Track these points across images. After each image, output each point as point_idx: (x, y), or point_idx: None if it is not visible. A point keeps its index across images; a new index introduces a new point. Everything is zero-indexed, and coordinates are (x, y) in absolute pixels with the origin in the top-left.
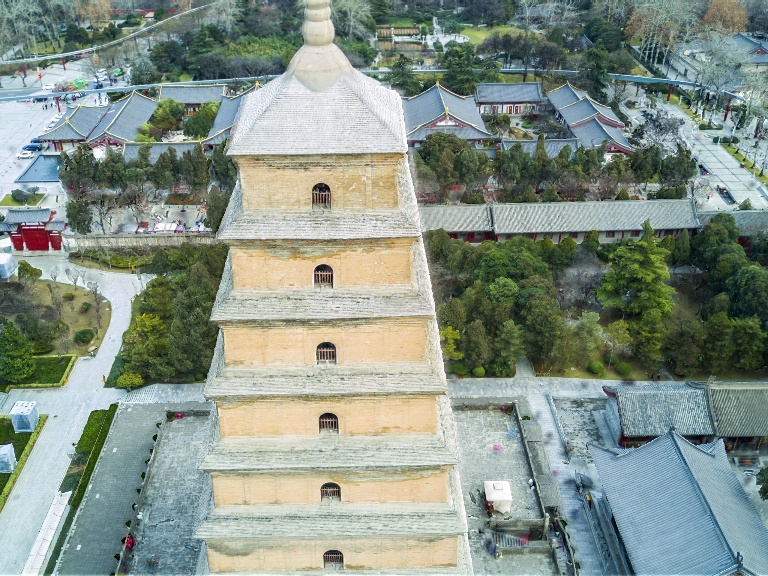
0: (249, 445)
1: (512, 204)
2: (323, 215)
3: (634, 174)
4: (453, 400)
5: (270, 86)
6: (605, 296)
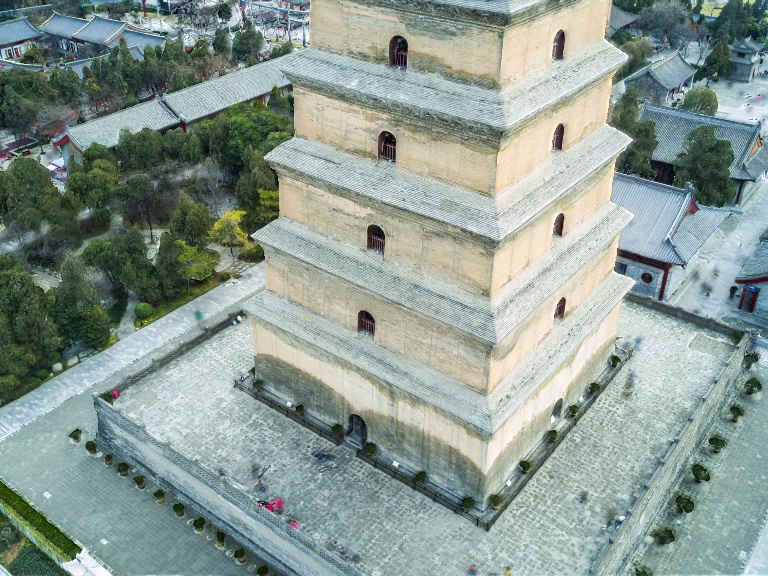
0: (516, 194)
1: (181, 91)
2: None
3: (221, 57)
4: None
5: None
6: None
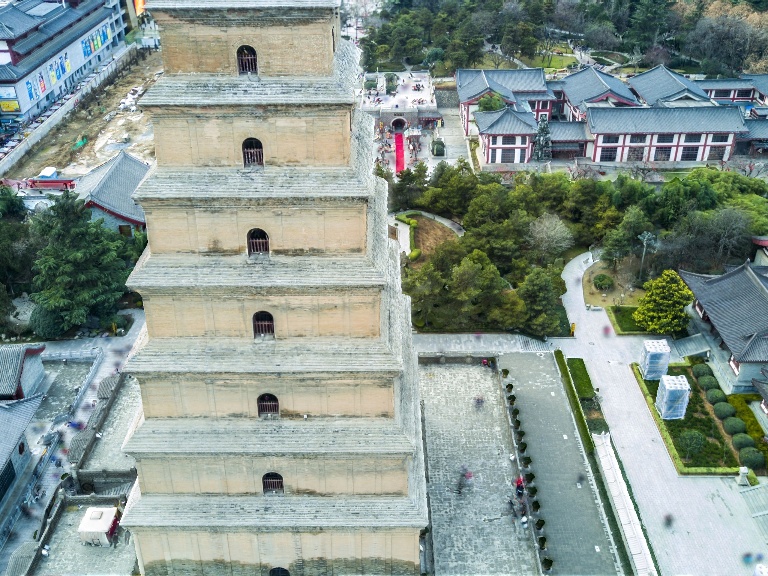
0: None
1: None
2: None
3: None
4: None
5: None
6: None
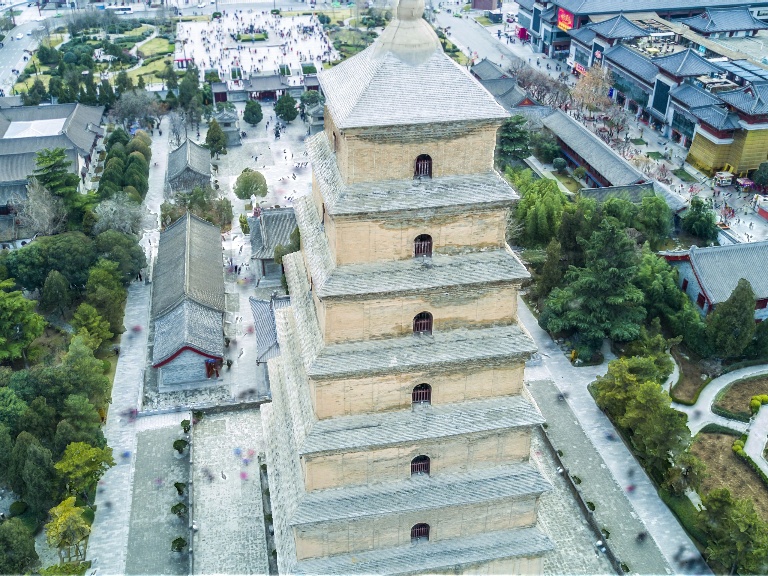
0: None
1: None
2: None
3: None
4: (138, 488)
5: (388, 85)
6: (5, 351)
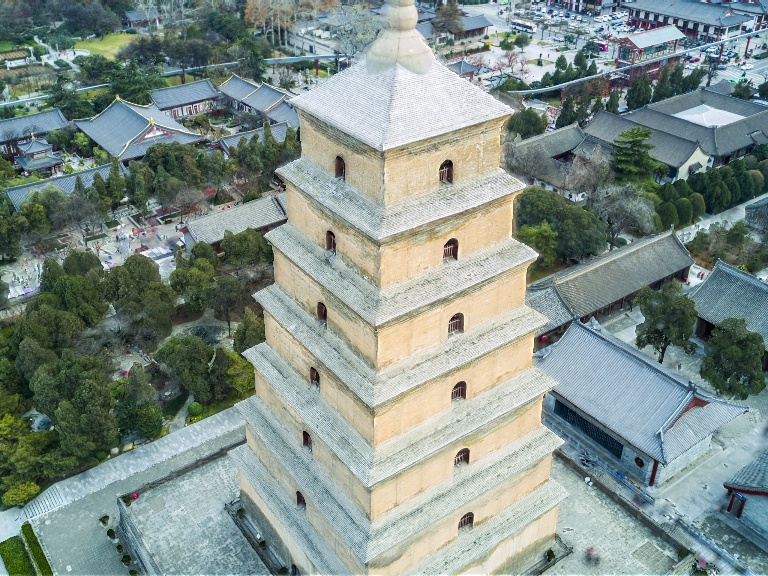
0: (400, 444)
1: None
2: (448, 191)
3: None
4: None
5: (341, 82)
6: None
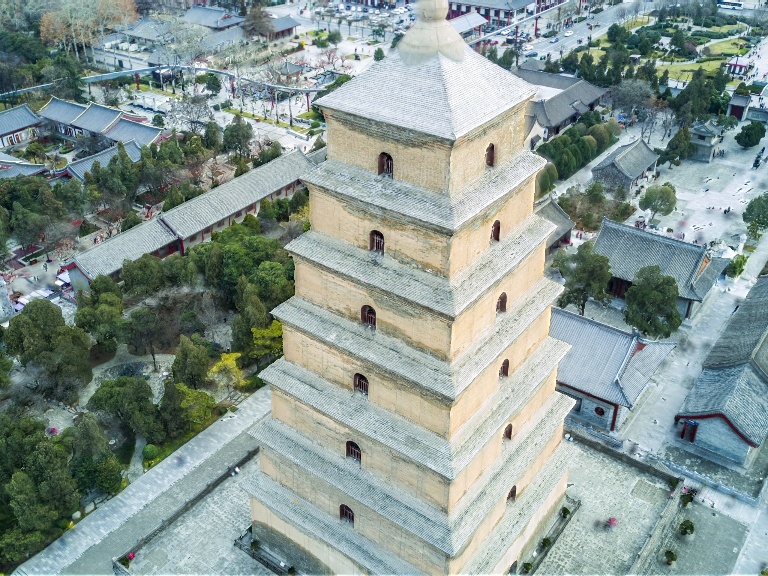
0: (467, 431)
1: (177, 207)
2: (491, 174)
3: (213, 151)
4: None
5: (375, 77)
6: None
